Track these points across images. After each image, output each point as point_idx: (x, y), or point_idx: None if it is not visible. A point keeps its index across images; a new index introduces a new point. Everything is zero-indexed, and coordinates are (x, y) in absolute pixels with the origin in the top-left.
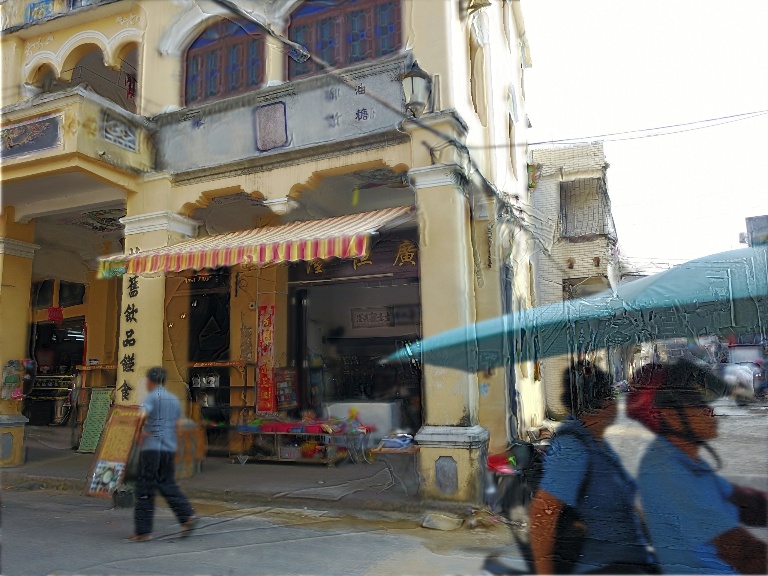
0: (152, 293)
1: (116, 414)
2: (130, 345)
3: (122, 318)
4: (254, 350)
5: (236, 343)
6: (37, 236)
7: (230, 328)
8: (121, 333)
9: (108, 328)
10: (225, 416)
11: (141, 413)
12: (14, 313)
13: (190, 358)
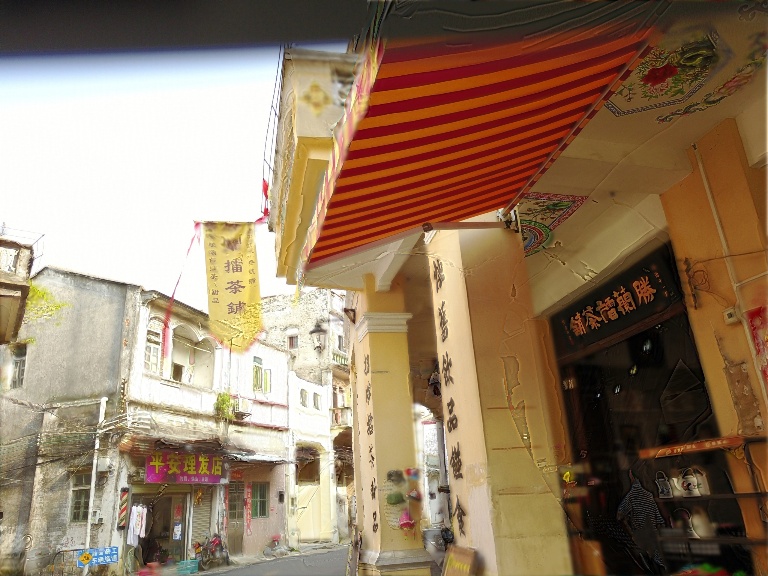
0: (458, 323)
1: (450, 564)
2: (453, 427)
3: (441, 381)
4: (763, 408)
5: (722, 400)
6: (407, 303)
7: (703, 372)
8: (444, 408)
9: (546, 411)
10: (745, 560)
11: (470, 567)
12: (386, 406)
13: (651, 442)
